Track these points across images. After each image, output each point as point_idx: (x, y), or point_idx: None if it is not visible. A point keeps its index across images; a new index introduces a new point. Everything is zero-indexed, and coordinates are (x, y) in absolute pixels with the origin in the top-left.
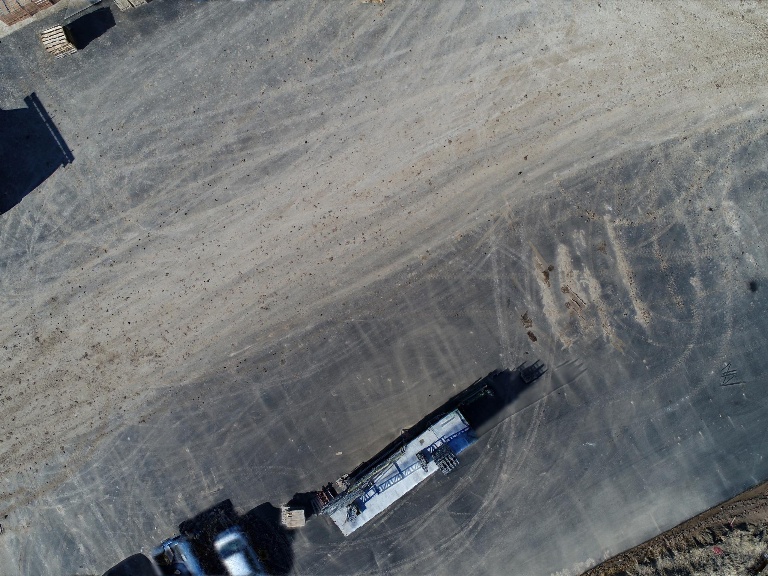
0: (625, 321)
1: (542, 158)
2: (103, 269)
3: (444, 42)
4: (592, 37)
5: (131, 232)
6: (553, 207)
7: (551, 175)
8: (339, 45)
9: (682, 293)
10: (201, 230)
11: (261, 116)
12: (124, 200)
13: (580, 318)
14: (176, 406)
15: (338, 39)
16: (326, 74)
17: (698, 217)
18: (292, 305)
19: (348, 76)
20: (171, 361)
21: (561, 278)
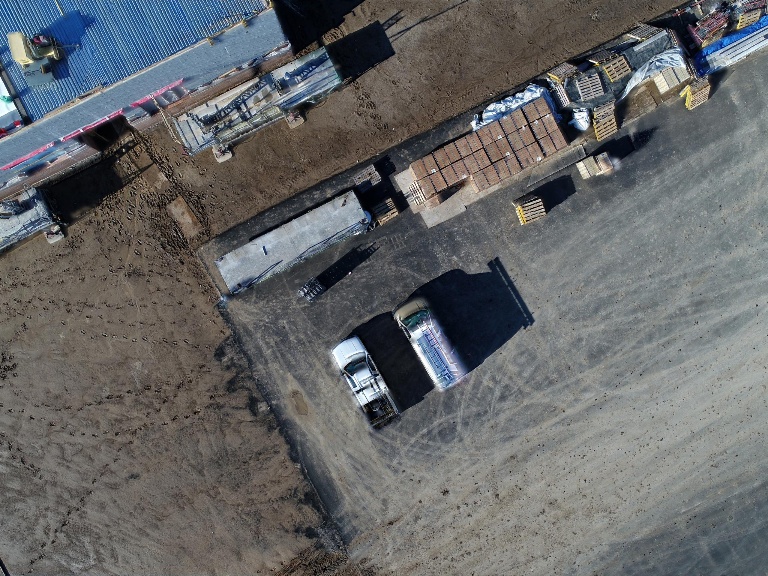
0: None
1: None
2: (561, 428)
3: None
4: None
5: (588, 392)
6: None
7: None
8: None
9: None
10: (655, 390)
11: (714, 280)
12: (582, 361)
13: None
14: (628, 561)
15: None
16: None
17: None
18: (741, 463)
19: None
20: (624, 517)
21: None
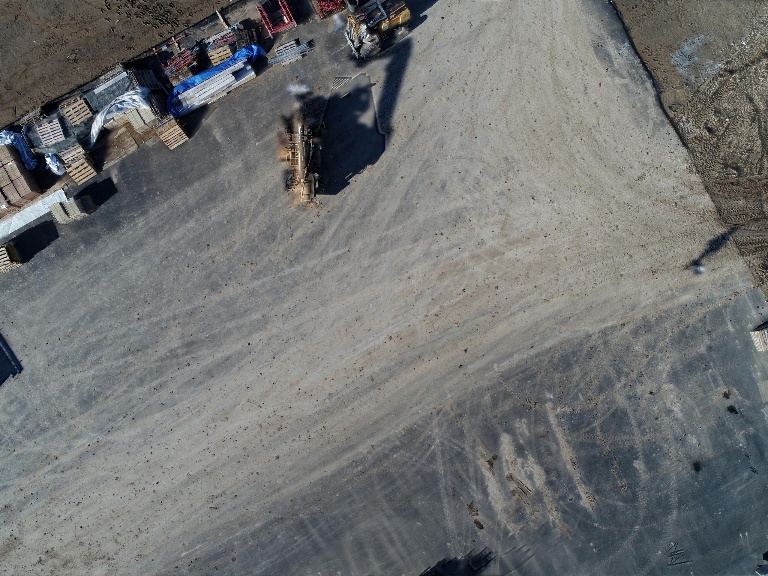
0: (570, 506)
1: (482, 350)
2: (54, 475)
3: (381, 241)
4: (527, 230)
5: (80, 438)
6: (495, 397)
7: (491, 366)
8: (278, 248)
9: (626, 476)
10: (149, 434)
11: (204, 320)
12: (73, 407)
13: (526, 505)
14: None
15: (277, 242)
16: (266, 276)
17: (639, 401)
18: (240, 503)
19: (288, 277)
20: (123, 563)
21: (505, 466)
